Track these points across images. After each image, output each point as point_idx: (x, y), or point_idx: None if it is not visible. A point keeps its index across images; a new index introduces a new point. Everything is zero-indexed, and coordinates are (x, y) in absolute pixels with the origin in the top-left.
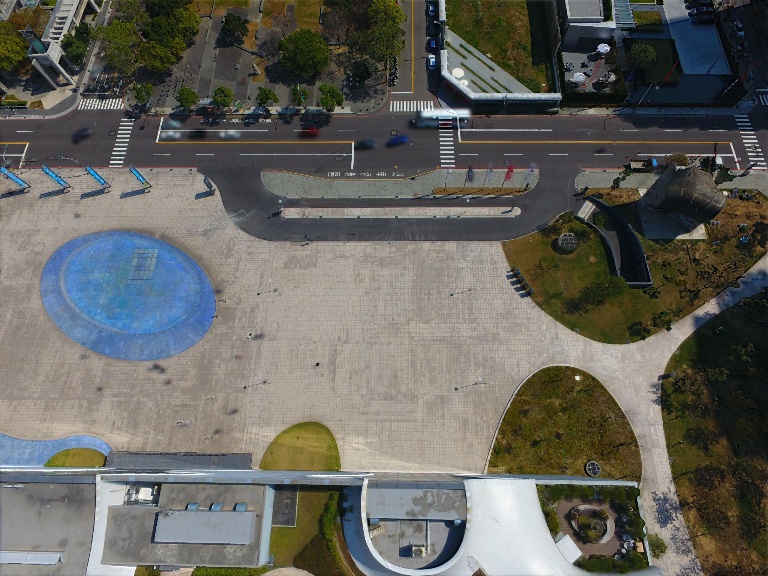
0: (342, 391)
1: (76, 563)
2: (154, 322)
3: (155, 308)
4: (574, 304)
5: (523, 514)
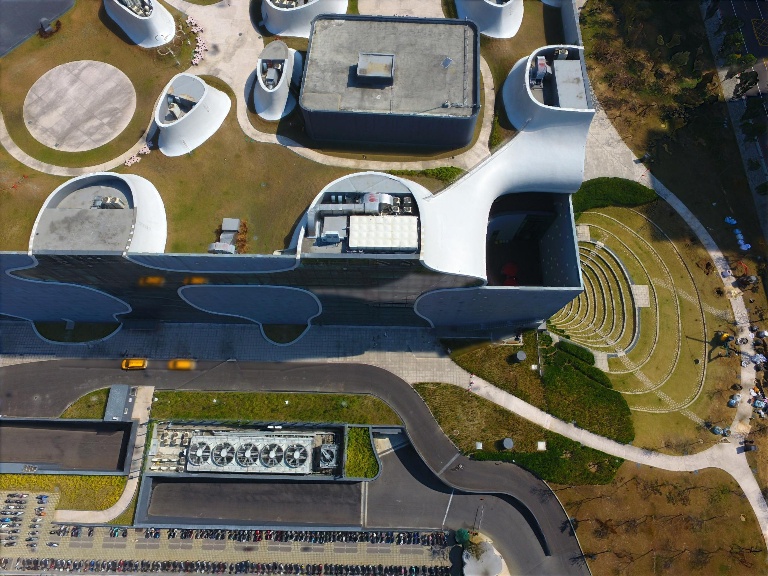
0: None
1: None
2: None
3: None
4: None
5: None
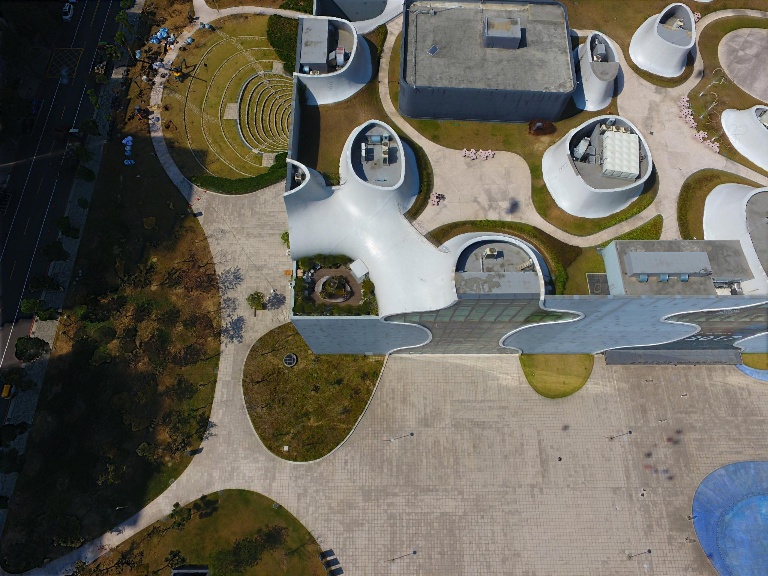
0: (529, 430)
1: (760, 239)
2: (760, 511)
3: (767, 530)
4: (272, 541)
5: (398, 287)
